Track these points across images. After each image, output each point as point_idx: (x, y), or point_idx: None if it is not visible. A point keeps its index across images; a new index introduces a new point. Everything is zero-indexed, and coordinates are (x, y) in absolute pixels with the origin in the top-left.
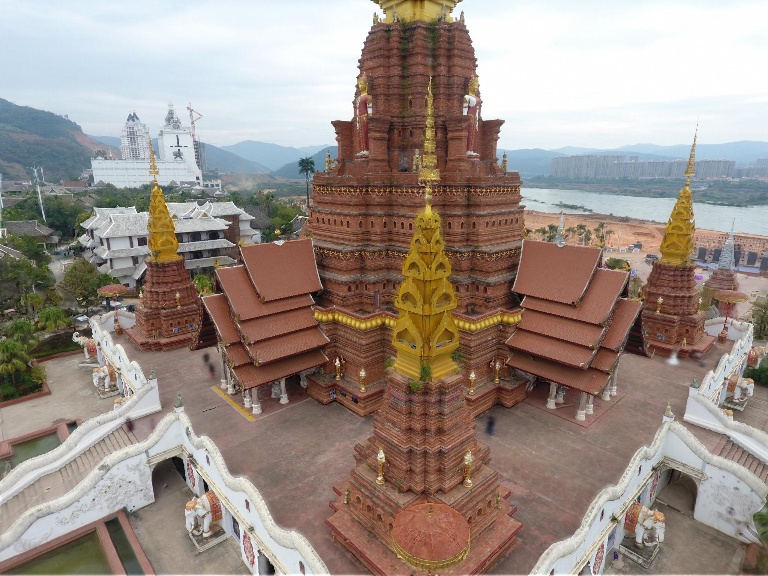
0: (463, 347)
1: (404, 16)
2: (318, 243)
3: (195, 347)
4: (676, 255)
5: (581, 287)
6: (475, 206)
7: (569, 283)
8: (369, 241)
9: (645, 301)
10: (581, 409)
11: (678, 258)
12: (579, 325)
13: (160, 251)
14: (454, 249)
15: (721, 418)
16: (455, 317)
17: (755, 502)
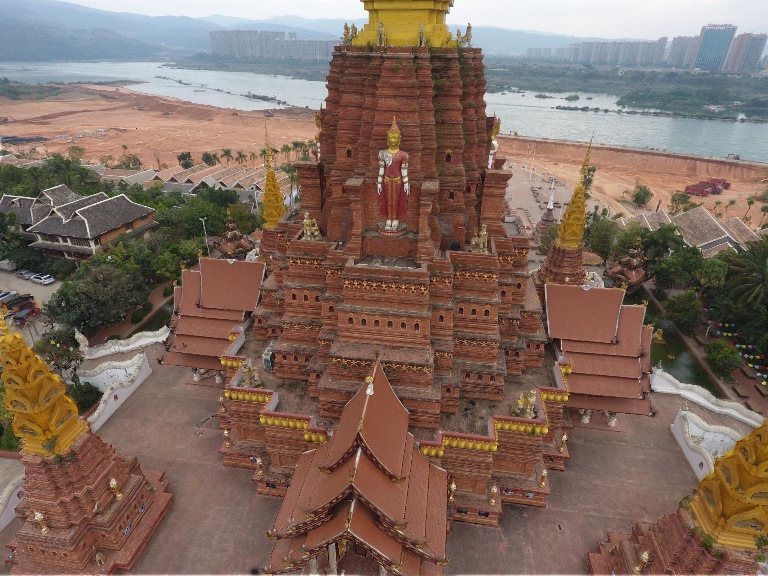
0: (551, 415)
1: (430, 37)
2: (367, 353)
3: (290, 571)
4: (574, 241)
5: (613, 326)
6: (518, 266)
7: (601, 323)
8: (433, 335)
9: (552, 280)
10: (615, 418)
11: (575, 242)
12: (619, 359)
13: (57, 435)
14: (509, 316)
15: (676, 384)
16: (546, 393)
17: (732, 445)
